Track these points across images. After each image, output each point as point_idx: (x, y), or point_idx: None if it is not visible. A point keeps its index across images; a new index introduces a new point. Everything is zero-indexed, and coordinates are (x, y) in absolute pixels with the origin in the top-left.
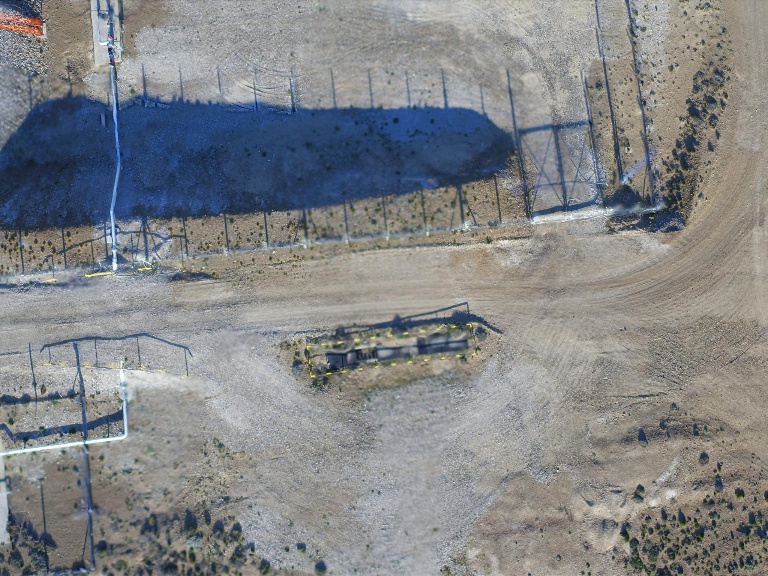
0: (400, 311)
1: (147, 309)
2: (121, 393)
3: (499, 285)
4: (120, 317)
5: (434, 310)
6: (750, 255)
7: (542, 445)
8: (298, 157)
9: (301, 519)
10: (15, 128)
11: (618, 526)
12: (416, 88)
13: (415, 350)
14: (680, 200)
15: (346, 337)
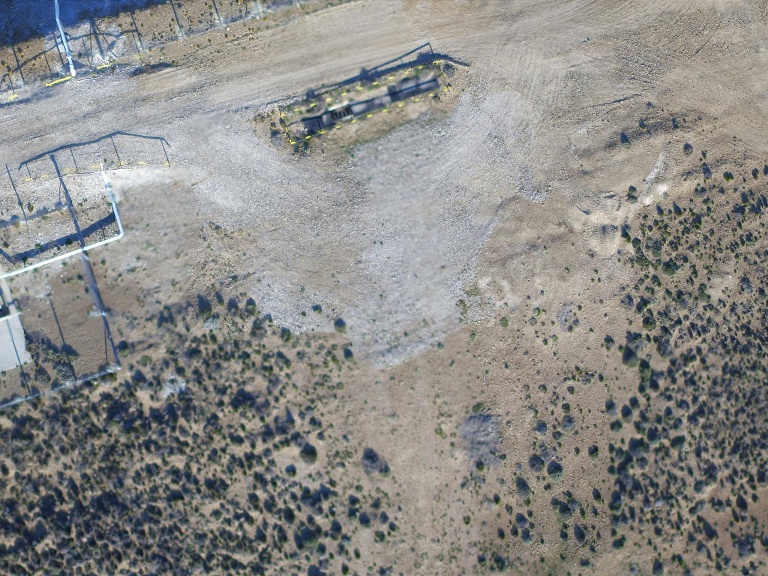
0: (365, 64)
1: (115, 108)
2: (108, 195)
3: (457, 20)
4: (90, 121)
5: (398, 57)
6: None
7: (530, 167)
8: None
9: (311, 283)
10: None
11: (618, 229)
12: None
13: (388, 99)
14: None
15: (317, 99)
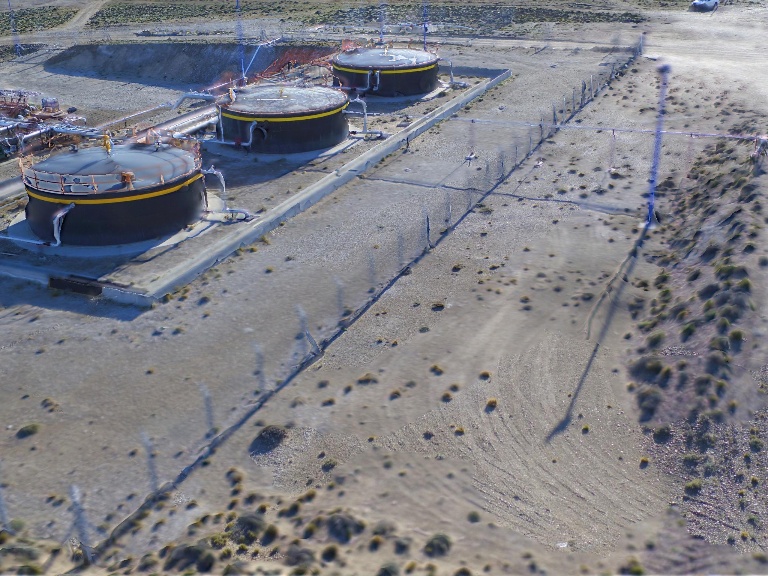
0: None
1: None
2: None
3: None
4: None
5: None
6: None
7: None
8: (150, 74)
9: None
10: None
11: None
12: None
13: None
14: (7, 49)
15: None
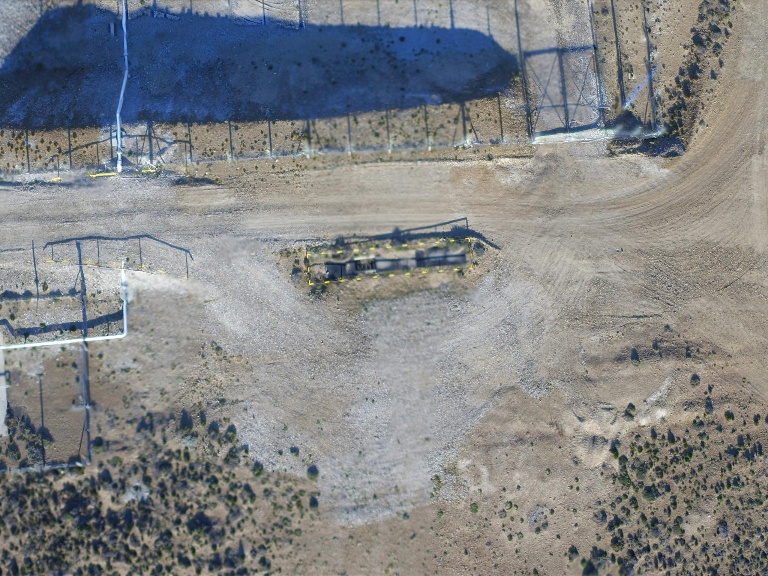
0: (400, 224)
1: (150, 211)
2: (122, 293)
3: (499, 202)
4: (123, 218)
5: (433, 224)
6: (748, 183)
7: (536, 361)
8: (304, 71)
9: (295, 424)
10: (25, 32)
11: (608, 443)
12: (423, 8)
13: (413, 263)
14: (681, 126)
15: (346, 247)
